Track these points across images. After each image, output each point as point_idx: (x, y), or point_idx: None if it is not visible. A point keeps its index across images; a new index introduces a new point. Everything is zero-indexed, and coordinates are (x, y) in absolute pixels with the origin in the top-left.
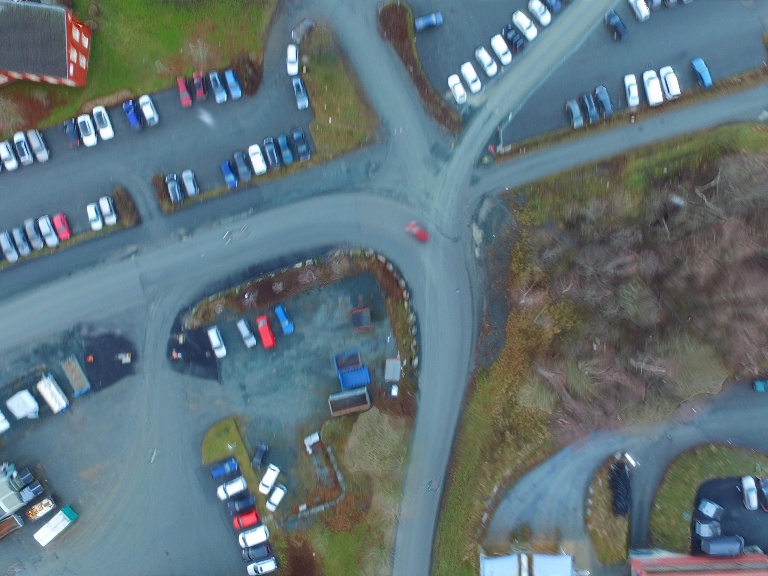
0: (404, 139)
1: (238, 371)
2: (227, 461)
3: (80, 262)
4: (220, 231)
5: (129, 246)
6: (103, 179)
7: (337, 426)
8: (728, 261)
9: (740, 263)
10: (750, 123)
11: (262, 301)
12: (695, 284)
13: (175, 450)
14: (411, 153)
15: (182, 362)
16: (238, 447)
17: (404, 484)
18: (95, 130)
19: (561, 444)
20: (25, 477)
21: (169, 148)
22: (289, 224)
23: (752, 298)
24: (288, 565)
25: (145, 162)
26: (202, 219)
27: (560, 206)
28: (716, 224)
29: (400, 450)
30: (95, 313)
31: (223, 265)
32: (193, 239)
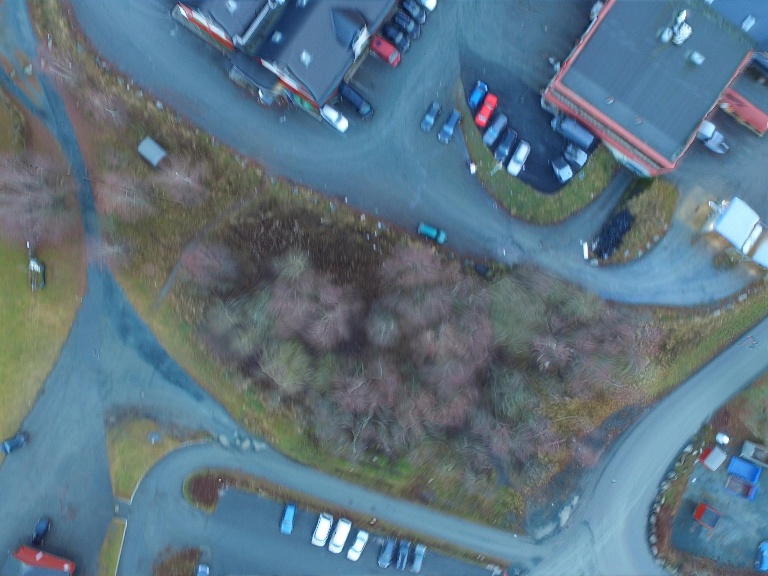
0: None
1: None
2: None
3: None
4: None
5: None
6: None
7: None
8: None
9: None
10: (278, 449)
11: None
12: None
13: None
14: None
15: None
16: None
17: None
18: None
19: (637, 309)
20: None
21: None
22: None
23: None
24: None
25: None
26: None
27: (484, 492)
28: None
29: None
30: None
31: None
32: None
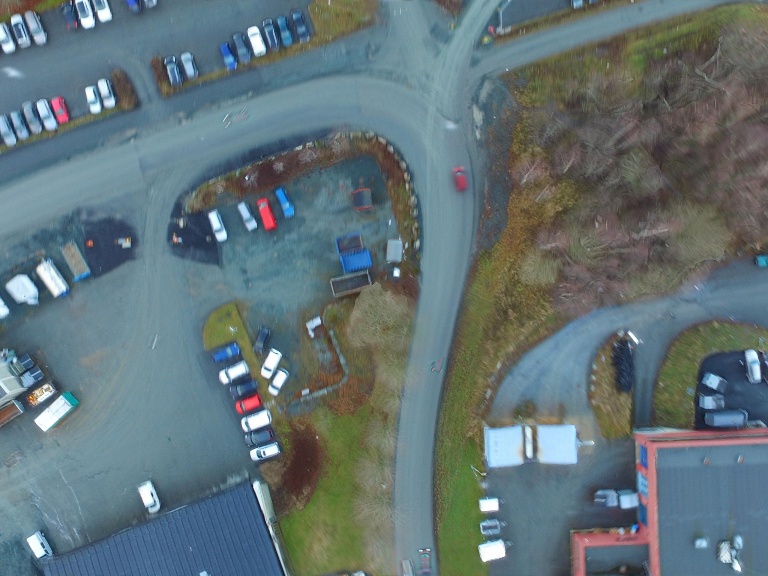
0: (404, 20)
1: (239, 255)
2: (229, 345)
3: (79, 146)
4: (220, 114)
5: (128, 130)
6: (101, 62)
7: (339, 310)
8: (729, 125)
9: (742, 122)
10: (749, 3)
11: (263, 184)
12: (697, 149)
13: (176, 336)
14: (411, 34)
15: (183, 246)
16: (240, 332)
17: (407, 365)
18: (93, 12)
19: (564, 321)
20: (25, 362)
21: (168, 31)
22: (289, 107)
23: (754, 152)
24: (291, 449)
25: (143, 45)
26: (201, 102)
27: (560, 87)
28: (717, 92)
29: (403, 320)
30: (94, 198)
31: (223, 148)
32: (193, 122)
